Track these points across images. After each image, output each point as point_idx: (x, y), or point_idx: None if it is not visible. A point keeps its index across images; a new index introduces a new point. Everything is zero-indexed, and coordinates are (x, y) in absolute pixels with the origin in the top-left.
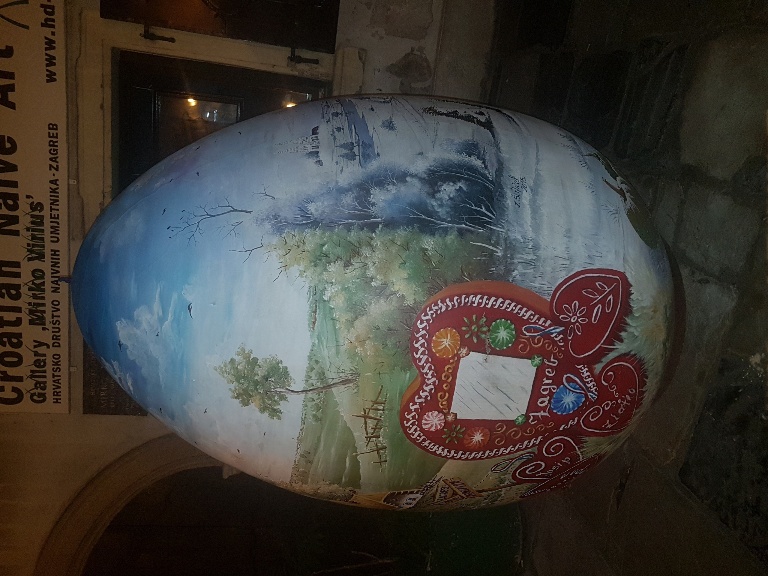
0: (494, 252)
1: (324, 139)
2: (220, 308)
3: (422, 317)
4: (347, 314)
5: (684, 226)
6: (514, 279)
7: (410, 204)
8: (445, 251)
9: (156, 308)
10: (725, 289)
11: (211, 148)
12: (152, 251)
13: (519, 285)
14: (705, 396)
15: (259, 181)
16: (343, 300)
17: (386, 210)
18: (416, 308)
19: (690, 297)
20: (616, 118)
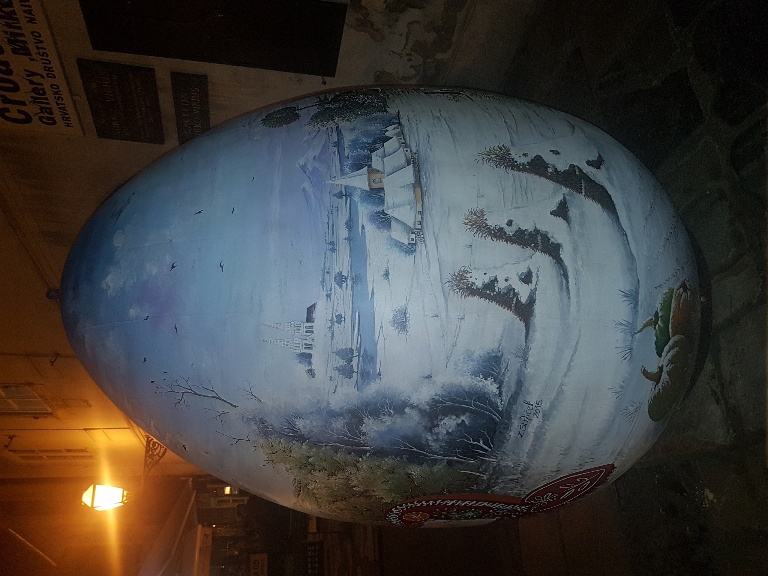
0: (479, 477)
1: (320, 335)
2: (212, 458)
3: (397, 507)
4: (329, 498)
5: (735, 330)
6: (493, 491)
7: (403, 437)
8: (430, 476)
9: (153, 429)
10: (725, 427)
11: (188, 281)
12: (139, 388)
13: (496, 494)
14: (661, 462)
15: (244, 375)
16: (325, 492)
17: (377, 441)
18: (393, 504)
19: (697, 391)
20: (759, 104)
